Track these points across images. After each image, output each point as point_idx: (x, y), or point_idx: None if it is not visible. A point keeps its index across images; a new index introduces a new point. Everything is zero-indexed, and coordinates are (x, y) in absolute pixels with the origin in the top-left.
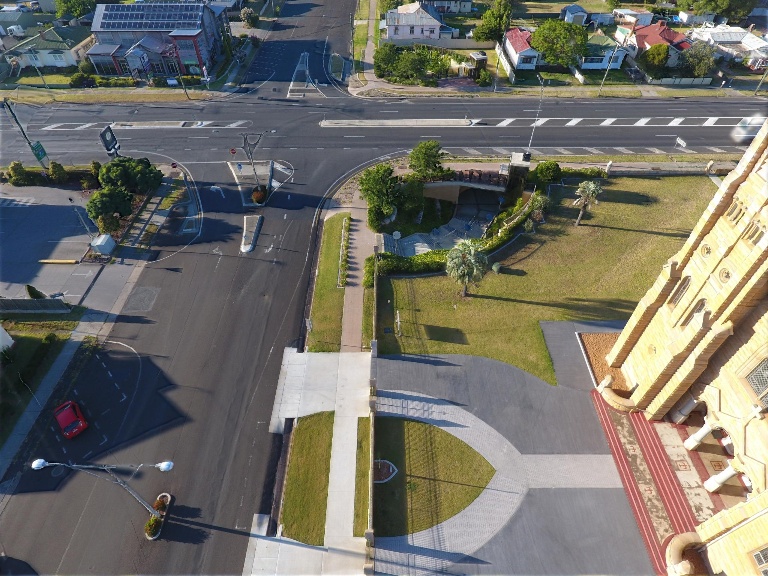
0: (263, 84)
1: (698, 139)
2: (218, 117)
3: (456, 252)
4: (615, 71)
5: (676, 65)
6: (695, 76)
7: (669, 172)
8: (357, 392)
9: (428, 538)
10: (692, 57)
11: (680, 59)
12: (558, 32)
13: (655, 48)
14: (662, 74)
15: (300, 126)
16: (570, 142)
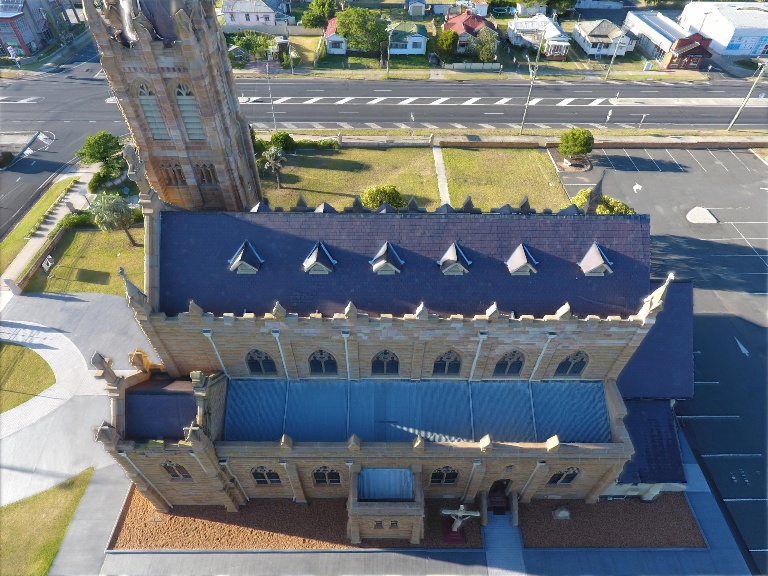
0: (80, 65)
1: (448, 116)
2: (15, 93)
3: None
4: (419, 56)
5: (465, 50)
6: (482, 61)
7: (396, 144)
8: None
9: None
10: (476, 43)
11: (467, 45)
12: (352, 18)
13: (444, 34)
14: (453, 59)
15: (86, 102)
16: (328, 118)
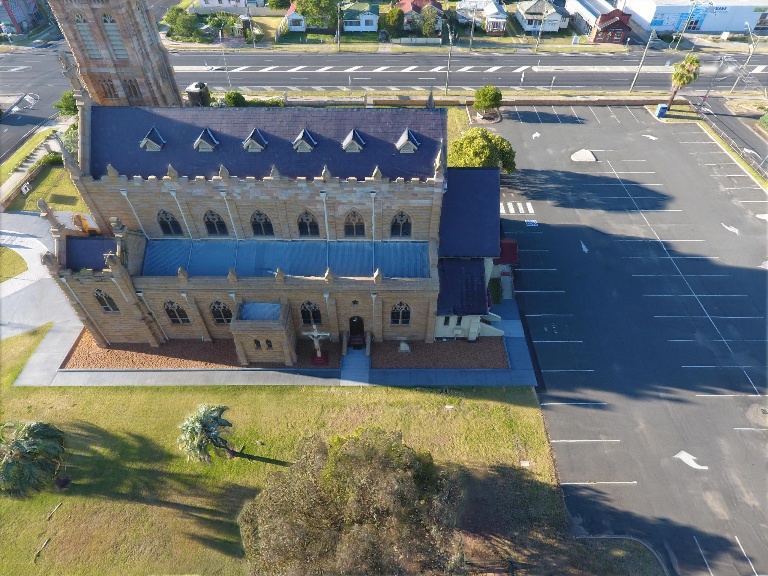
0: None
1: (385, 81)
2: (7, 64)
3: None
4: (372, 33)
5: (410, 26)
6: (425, 35)
7: (335, 102)
8: None
9: None
10: (419, 19)
11: (412, 21)
12: None
13: (390, 11)
14: (400, 34)
15: None
16: (280, 82)
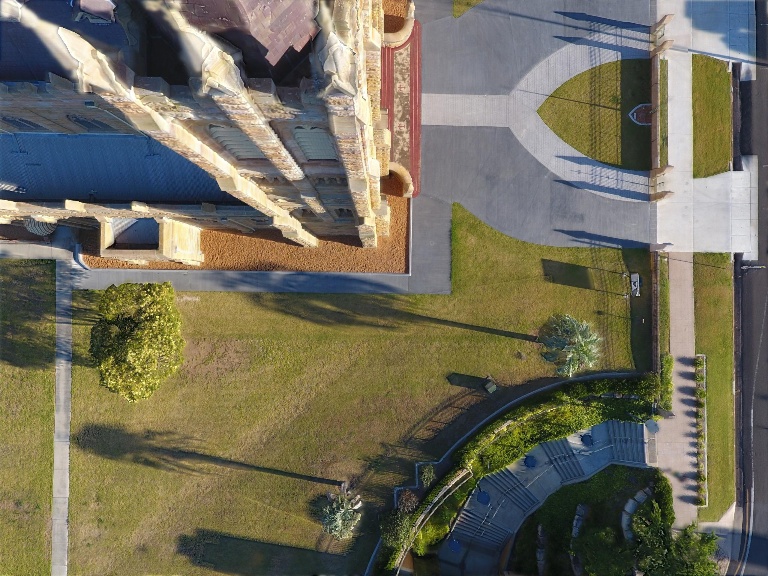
0: None
1: None
2: None
3: (592, 353)
4: None
5: None
6: None
7: None
8: (671, 199)
9: (605, 56)
10: None
11: None
12: None
13: None
14: None
15: None
16: None
